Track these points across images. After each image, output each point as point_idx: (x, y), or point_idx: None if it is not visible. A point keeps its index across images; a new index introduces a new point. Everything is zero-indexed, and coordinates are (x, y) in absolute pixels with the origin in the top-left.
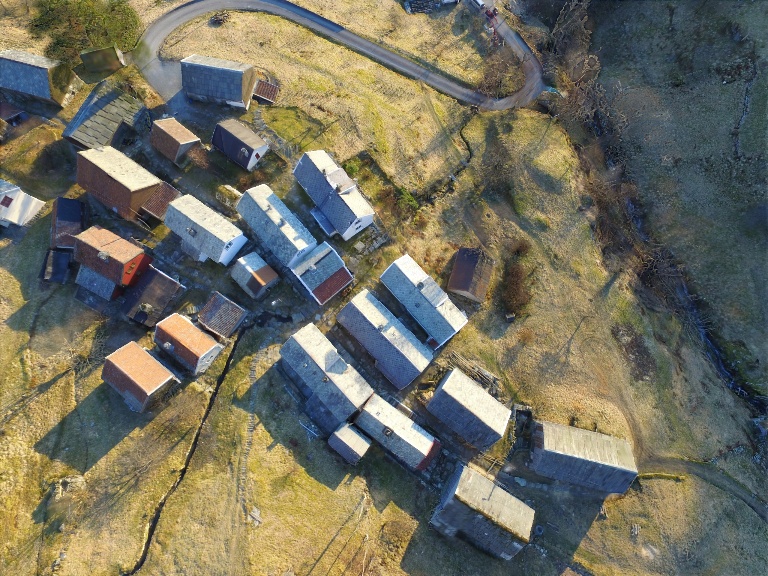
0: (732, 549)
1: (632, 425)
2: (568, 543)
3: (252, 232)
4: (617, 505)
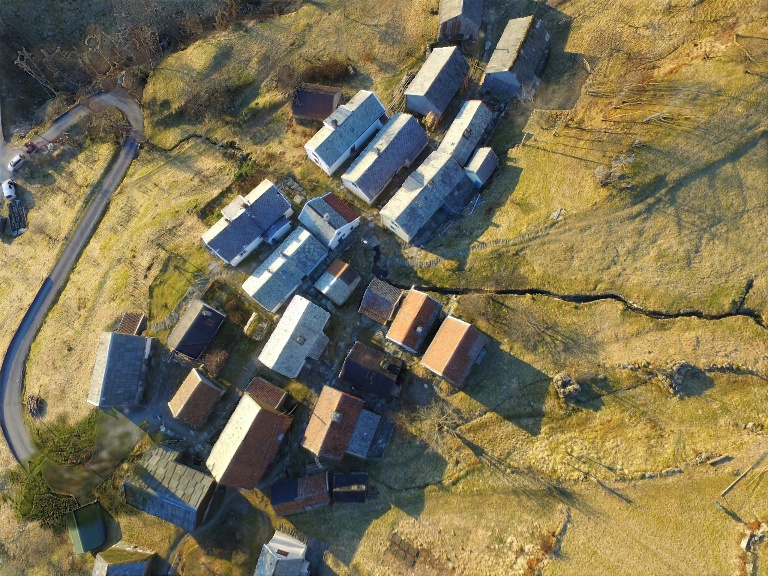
0: None
1: None
2: (528, 6)
3: None
4: None
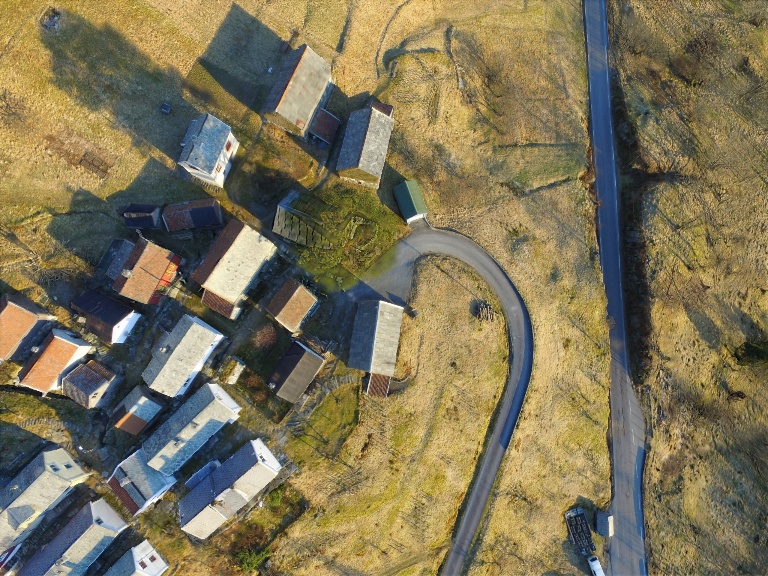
0: None
1: None
2: None
3: None
4: None
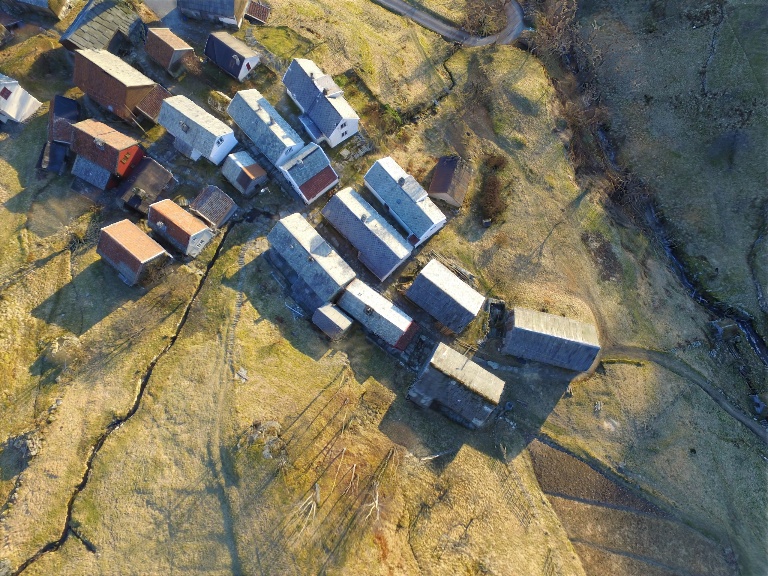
0: (687, 424)
1: (598, 318)
2: (536, 418)
3: (242, 137)
4: (582, 385)
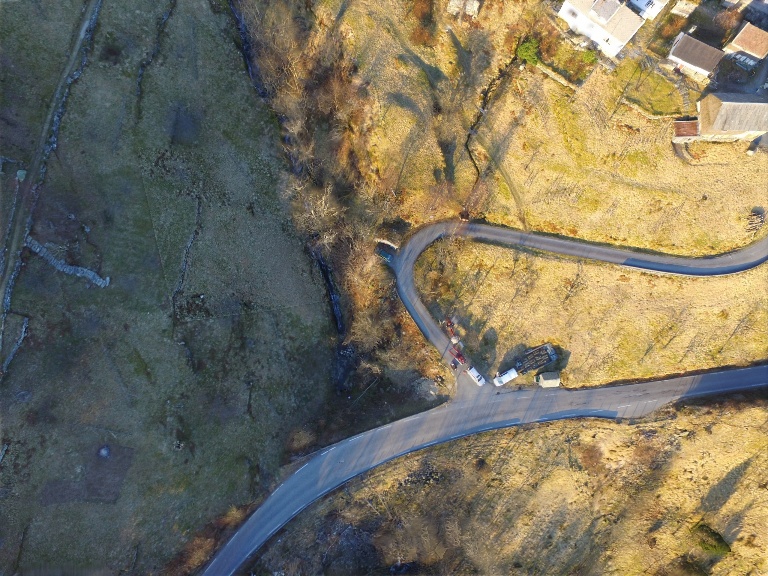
0: None
1: None
2: None
3: None
4: None
